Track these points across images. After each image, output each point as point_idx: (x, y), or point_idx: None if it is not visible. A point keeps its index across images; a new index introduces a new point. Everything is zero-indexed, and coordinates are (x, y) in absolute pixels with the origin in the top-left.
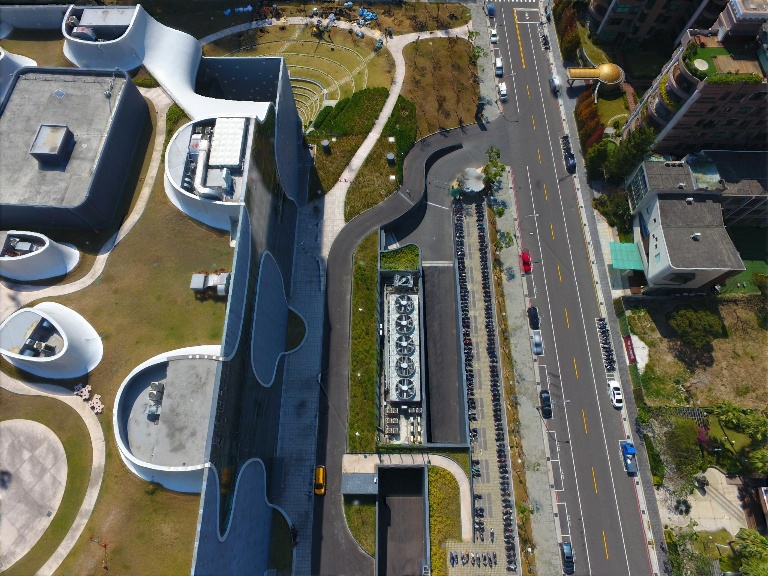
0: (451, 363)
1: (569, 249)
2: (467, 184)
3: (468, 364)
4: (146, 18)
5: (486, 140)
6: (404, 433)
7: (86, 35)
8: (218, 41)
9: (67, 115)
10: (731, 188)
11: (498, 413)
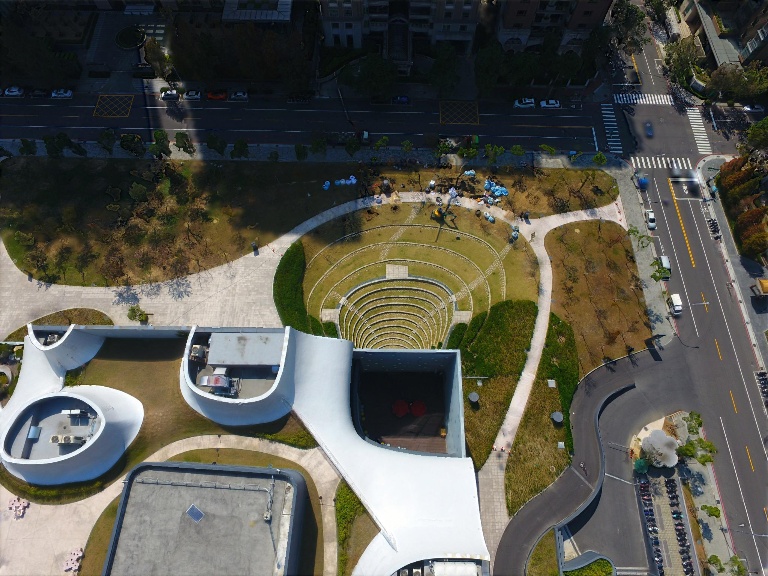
0: None
1: None
2: (657, 456)
3: None
4: (295, 339)
5: (663, 376)
6: None
7: (220, 386)
8: (319, 229)
9: (211, 560)
10: None
11: None
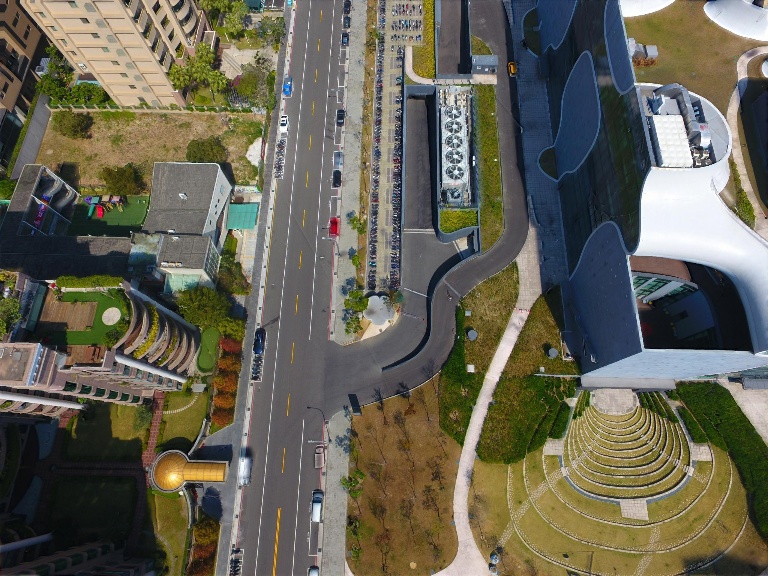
0: (410, 156)
1: (289, 241)
2: None
3: (398, 145)
4: None
5: (352, 379)
6: (452, 99)
7: None
8: (753, 573)
9: None
10: (122, 246)
11: (379, 112)
